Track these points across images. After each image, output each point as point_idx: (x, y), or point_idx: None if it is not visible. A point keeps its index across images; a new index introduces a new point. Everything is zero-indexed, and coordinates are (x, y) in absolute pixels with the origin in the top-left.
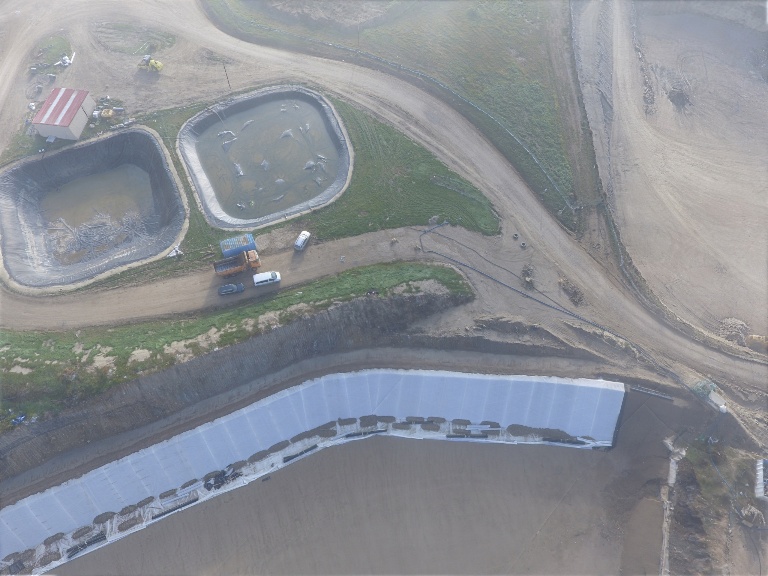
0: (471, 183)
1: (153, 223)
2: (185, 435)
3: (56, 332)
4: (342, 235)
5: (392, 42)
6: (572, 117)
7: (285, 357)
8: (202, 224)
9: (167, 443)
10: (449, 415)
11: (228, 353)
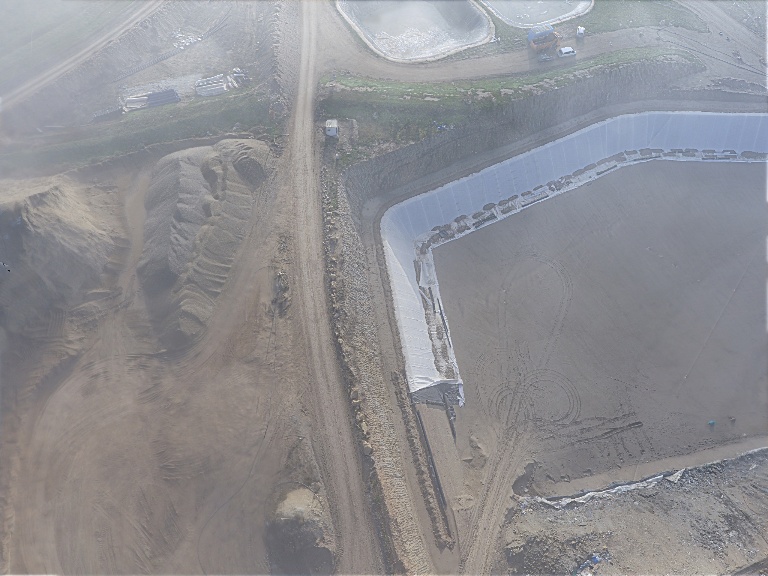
0: (677, 3)
1: (453, 33)
2: (539, 148)
3: (438, 83)
4: (604, 31)
5: None
6: None
7: (590, 103)
8: (504, 24)
9: (529, 153)
10: (700, 147)
11: (562, 93)
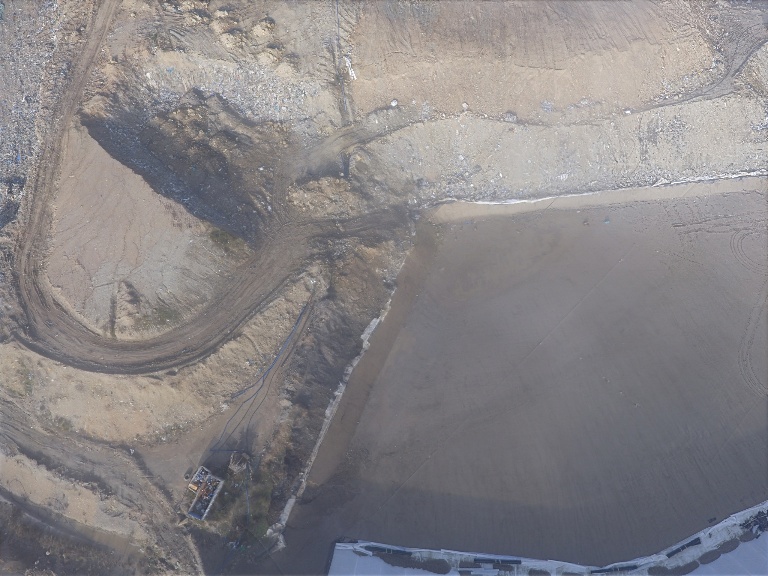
0: None
1: None
2: None
3: None
4: None
5: None
6: None
7: None
8: None
9: None
10: None
11: None
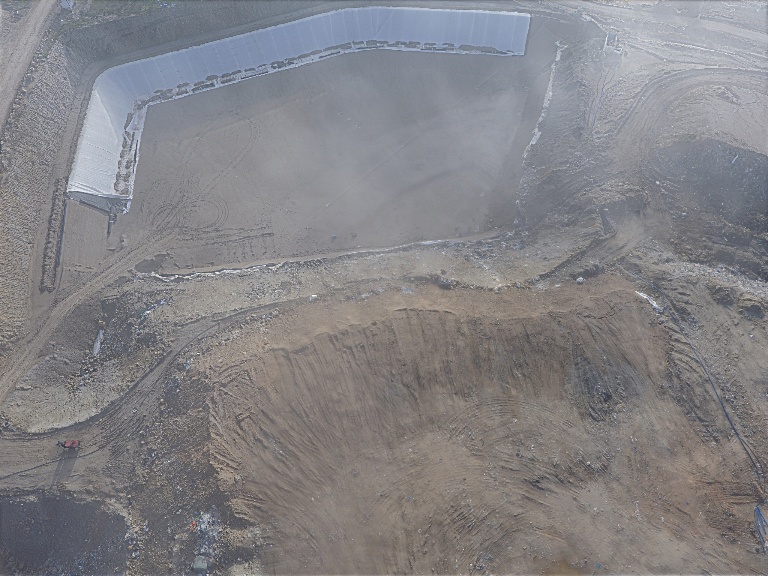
0: None
1: None
2: (260, 30)
3: None
4: None
5: None
6: None
7: None
8: None
9: (250, 33)
10: (422, 40)
11: None
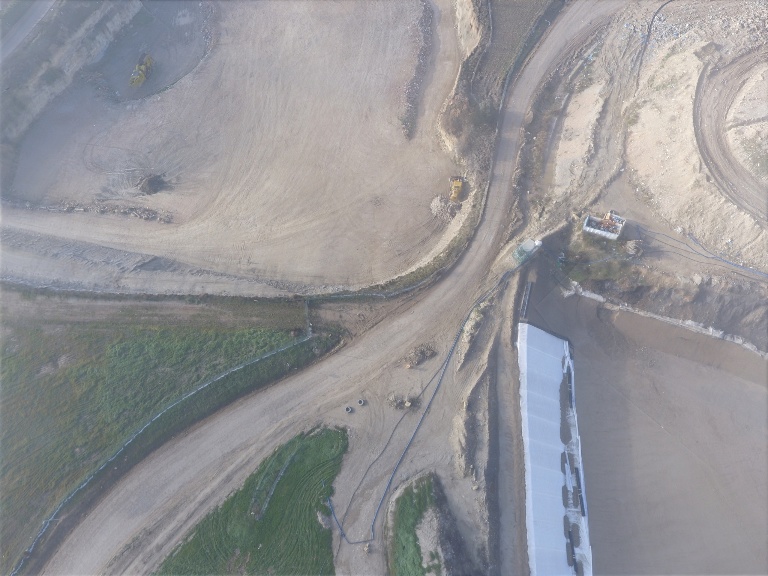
0: (266, 459)
1: None
2: None
3: None
4: None
5: None
6: (177, 313)
7: None
8: None
9: None
10: (561, 511)
11: None
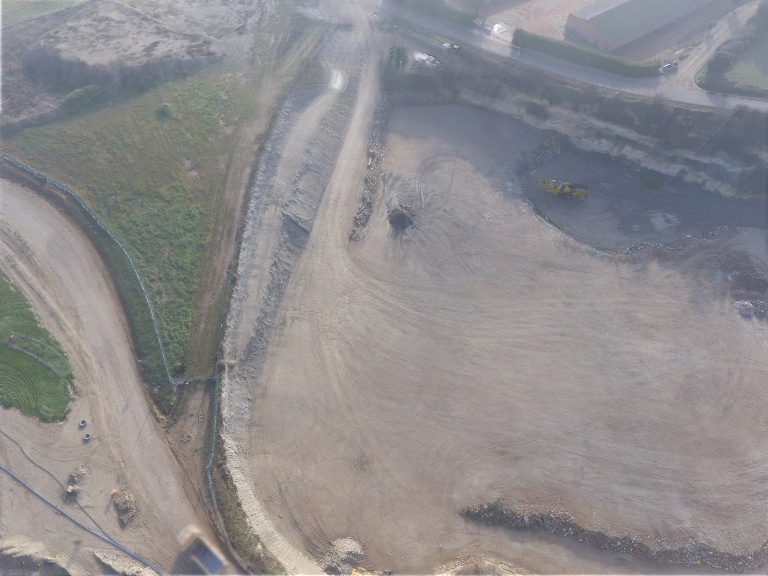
0: (59, 345)
1: None
2: None
3: None
4: None
5: (51, 146)
6: (221, 256)
7: None
8: None
9: None
10: None
11: None
